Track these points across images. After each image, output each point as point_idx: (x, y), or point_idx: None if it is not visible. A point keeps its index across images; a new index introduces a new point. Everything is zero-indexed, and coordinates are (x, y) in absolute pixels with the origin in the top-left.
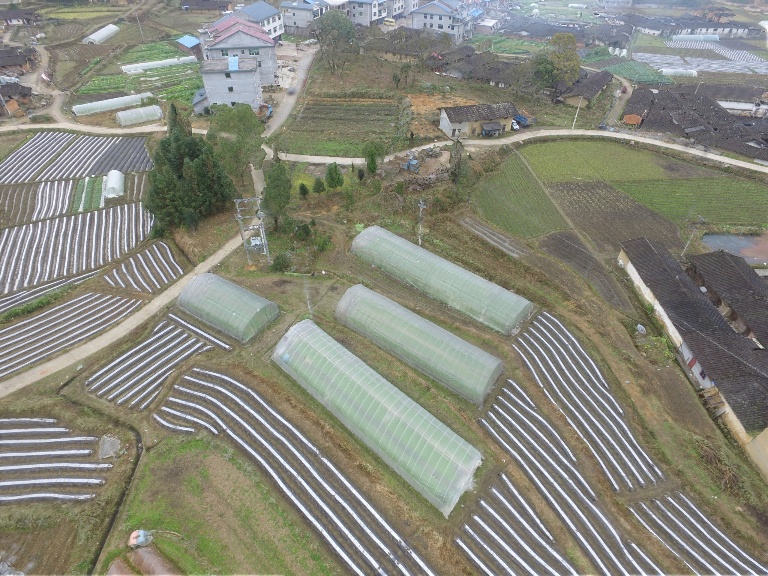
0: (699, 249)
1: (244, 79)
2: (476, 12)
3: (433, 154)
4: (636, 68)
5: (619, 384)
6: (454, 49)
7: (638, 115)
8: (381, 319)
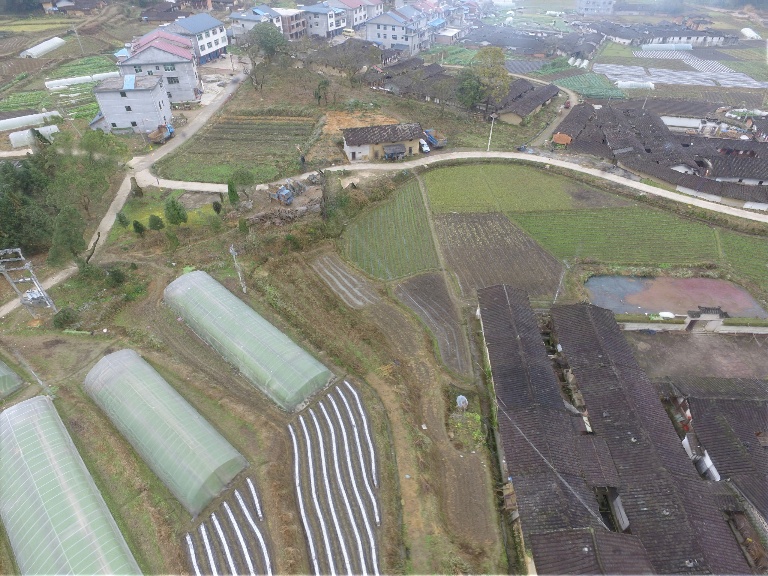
0: (577, 295)
1: (141, 98)
2: (437, 21)
3: (317, 181)
4: (592, 80)
5: (397, 479)
6: (402, 61)
7: (567, 134)
8: (121, 398)
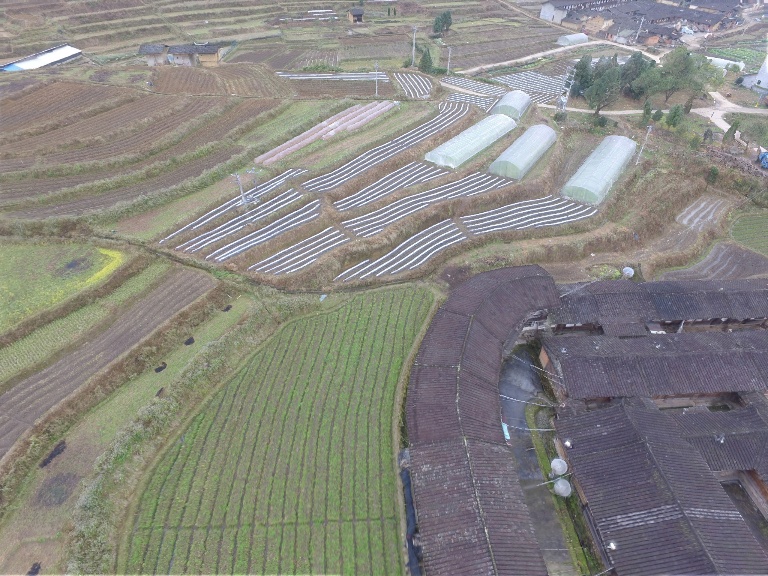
0: None
1: None
2: None
3: None
4: None
5: None
6: None
7: None
8: None
